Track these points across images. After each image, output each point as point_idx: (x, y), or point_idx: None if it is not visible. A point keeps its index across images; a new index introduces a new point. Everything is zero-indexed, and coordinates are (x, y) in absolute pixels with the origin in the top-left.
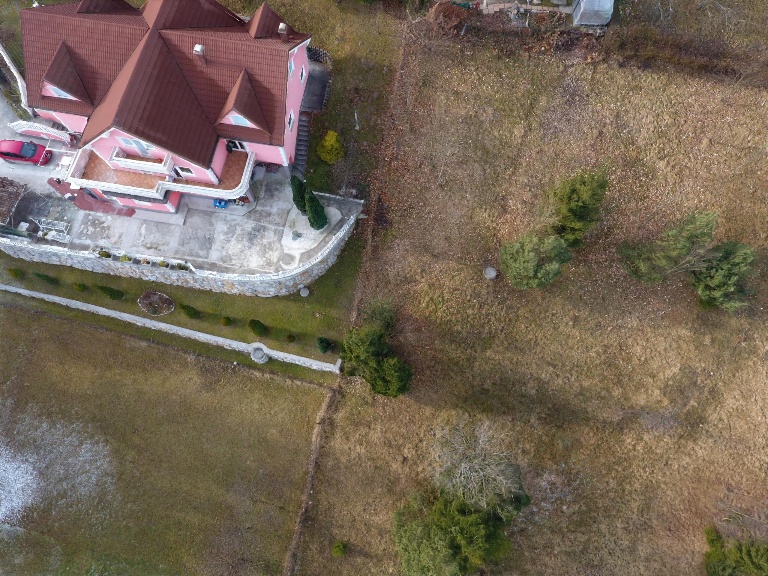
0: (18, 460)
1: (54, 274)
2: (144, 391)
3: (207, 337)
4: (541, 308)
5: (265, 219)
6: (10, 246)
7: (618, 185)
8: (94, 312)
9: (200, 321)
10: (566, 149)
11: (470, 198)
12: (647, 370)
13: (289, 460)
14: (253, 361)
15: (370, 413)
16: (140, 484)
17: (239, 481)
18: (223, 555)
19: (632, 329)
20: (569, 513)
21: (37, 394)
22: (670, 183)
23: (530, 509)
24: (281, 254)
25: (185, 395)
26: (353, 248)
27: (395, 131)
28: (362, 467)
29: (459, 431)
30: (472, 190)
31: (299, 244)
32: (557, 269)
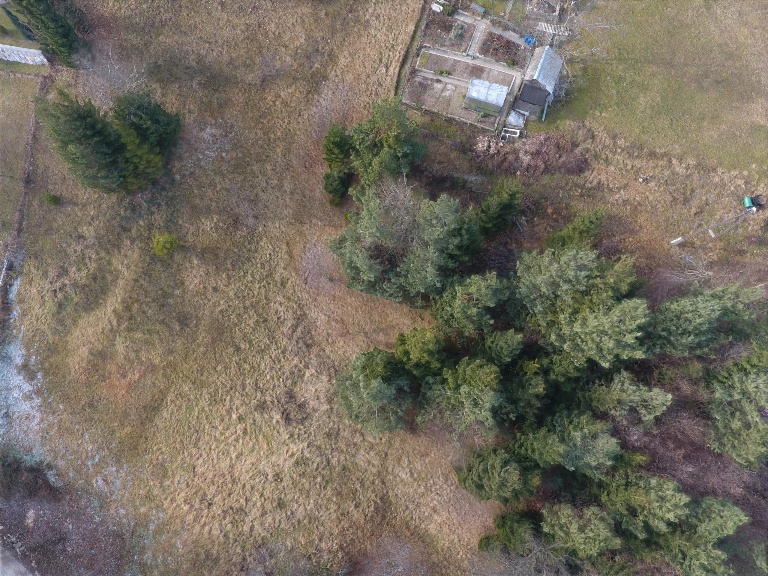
0: None
1: None
2: None
3: None
4: None
5: None
6: None
7: None
8: None
9: None
10: None
11: None
12: (281, 42)
13: (15, 137)
14: None
15: (73, 93)
16: None
17: None
18: None
19: (267, 10)
20: (228, 159)
21: None
22: None
23: (197, 156)
24: None
25: None
26: None
27: None
28: None
29: None
30: None
31: None
32: None
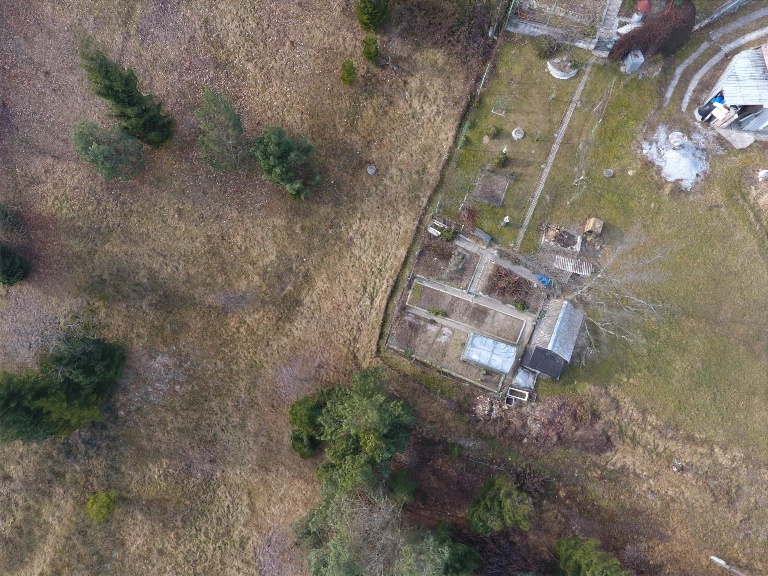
0: None
1: None
2: None
3: None
4: (150, 203)
5: None
6: None
7: (211, 86)
8: None
9: None
10: (163, 53)
11: (80, 101)
12: (248, 258)
13: None
14: None
15: (4, 305)
16: None
17: None
18: None
19: (232, 220)
20: (182, 393)
21: None
22: (260, 84)
23: (145, 389)
24: None
25: None
26: None
27: (11, 40)
28: None
29: (79, 318)
30: (82, 94)
31: None
32: (106, 151)
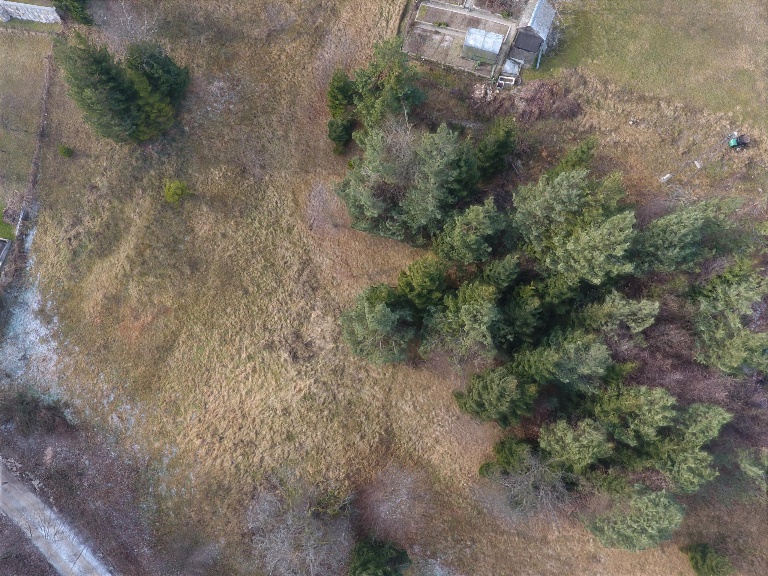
0: None
1: None
2: None
3: None
4: None
5: None
6: None
7: None
8: None
9: None
10: None
11: None
12: None
13: (29, 93)
14: None
15: None
16: None
17: None
18: None
19: None
20: (235, 111)
21: None
22: None
23: (205, 109)
24: None
25: None
26: None
27: None
28: None
29: None
30: None
31: None
32: None
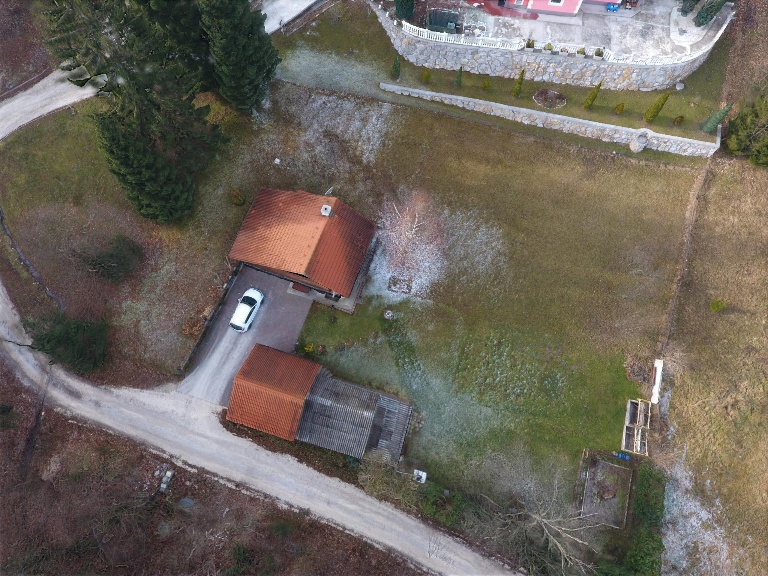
0: (424, 243)
1: (454, 78)
2: (531, 181)
3: (600, 125)
4: None
5: (651, 20)
6: (435, 45)
7: None
8: (486, 113)
9: (591, 112)
10: None
11: None
12: None
13: (664, 235)
14: (629, 151)
15: (739, 189)
16: (529, 263)
17: (615, 258)
18: (602, 323)
19: None
20: None
21: (438, 186)
22: None
23: None
24: (673, 46)
25: (568, 183)
26: (722, 46)
27: None
28: (736, 234)
29: None
30: None
31: (686, 38)
32: None
